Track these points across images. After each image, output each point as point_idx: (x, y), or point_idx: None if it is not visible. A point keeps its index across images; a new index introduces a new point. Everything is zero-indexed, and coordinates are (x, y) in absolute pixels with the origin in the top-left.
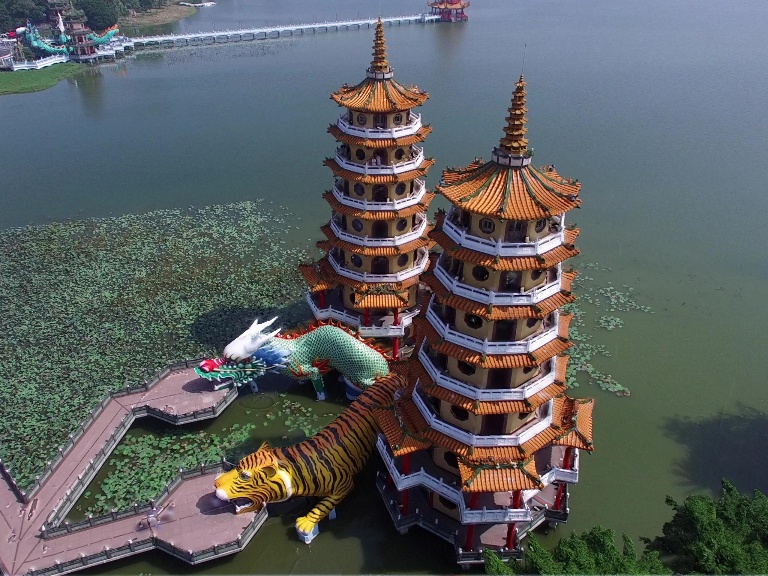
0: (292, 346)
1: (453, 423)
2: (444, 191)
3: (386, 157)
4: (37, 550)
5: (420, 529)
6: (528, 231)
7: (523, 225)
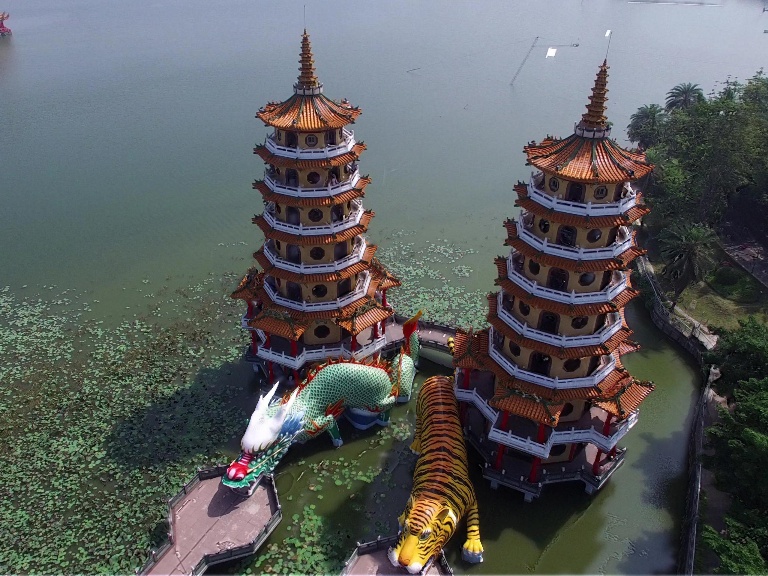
0: (300, 406)
1: (564, 378)
2: (564, 174)
3: (339, 174)
4: None
5: (547, 486)
6: (623, 188)
7: (621, 184)
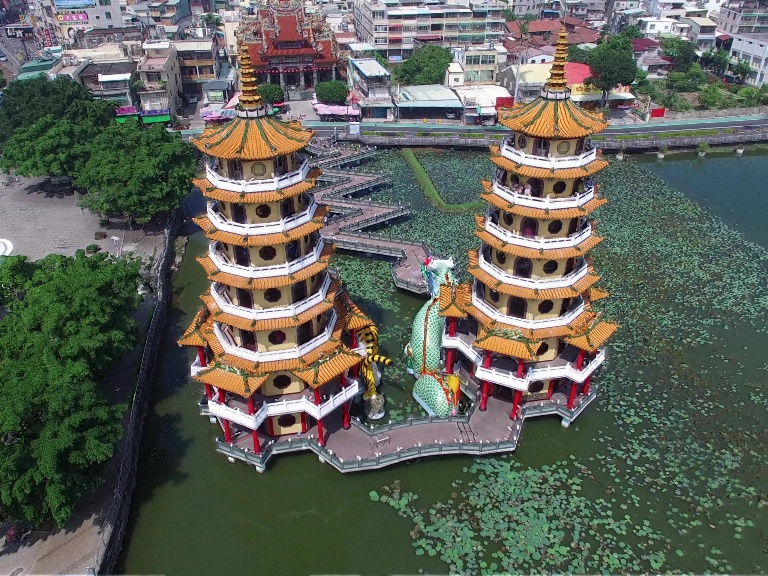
0: None
1: None
2: None
3: None
4: None
5: None
6: None
7: None
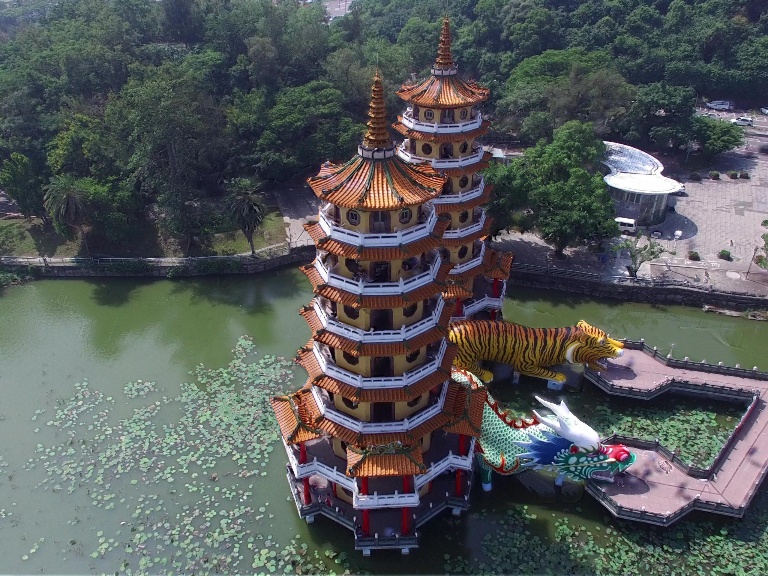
0: None
1: None
2: None
3: None
4: (761, 393)
5: None
6: None
7: None
